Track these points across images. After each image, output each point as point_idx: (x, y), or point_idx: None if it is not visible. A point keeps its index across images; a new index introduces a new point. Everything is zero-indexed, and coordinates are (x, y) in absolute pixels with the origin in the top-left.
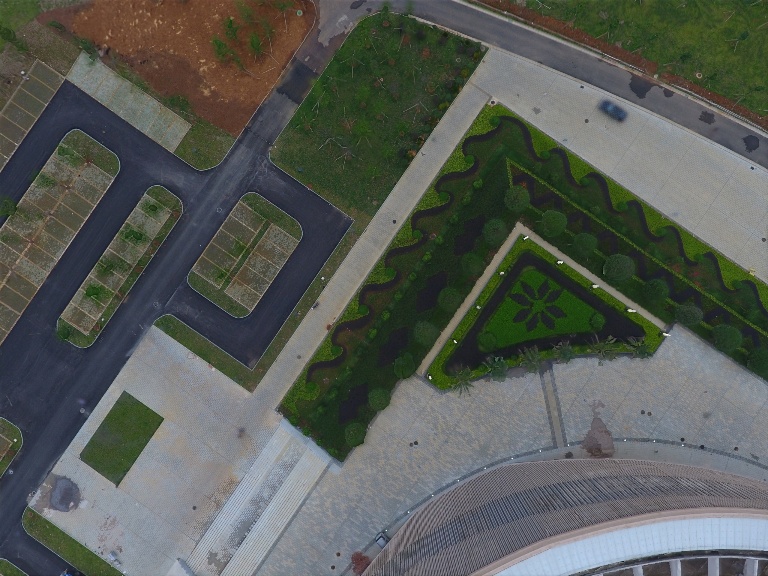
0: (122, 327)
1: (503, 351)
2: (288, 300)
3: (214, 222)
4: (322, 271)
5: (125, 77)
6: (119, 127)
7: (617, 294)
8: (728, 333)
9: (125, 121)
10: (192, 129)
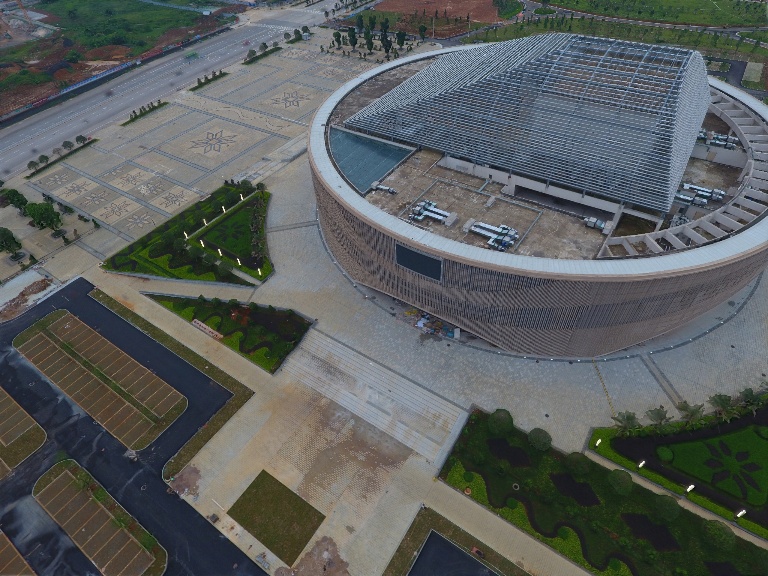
0: None
1: None
2: None
3: None
4: None
5: None
6: None
7: None
8: None
9: None
10: None
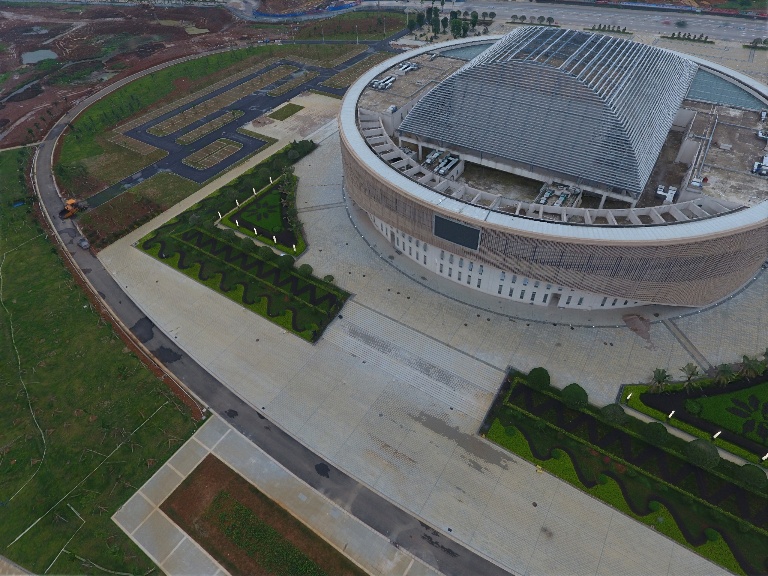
0: None
1: (763, 380)
2: None
3: None
4: None
5: None
6: None
7: (679, 435)
8: (584, 396)
9: None
10: None
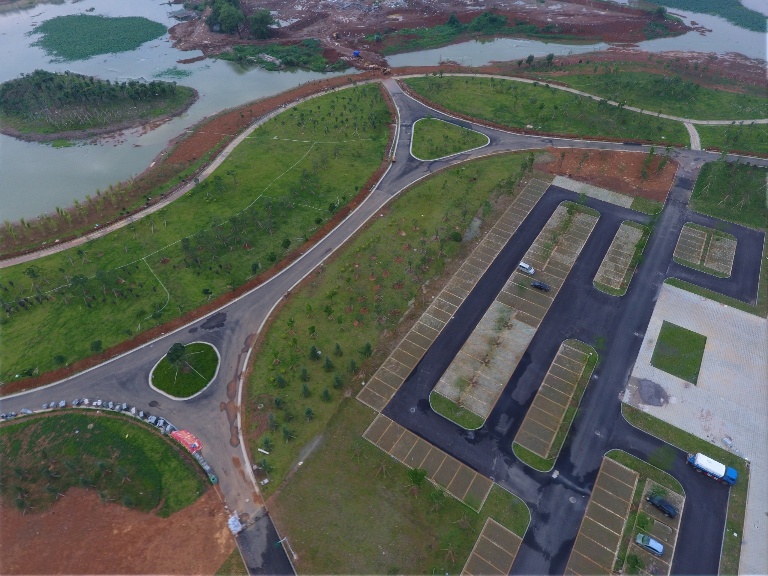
0: (641, 285)
1: None
2: (752, 269)
3: (673, 235)
4: (764, 255)
5: (585, 183)
6: (591, 200)
7: None
8: None
9: (593, 198)
10: (635, 200)
